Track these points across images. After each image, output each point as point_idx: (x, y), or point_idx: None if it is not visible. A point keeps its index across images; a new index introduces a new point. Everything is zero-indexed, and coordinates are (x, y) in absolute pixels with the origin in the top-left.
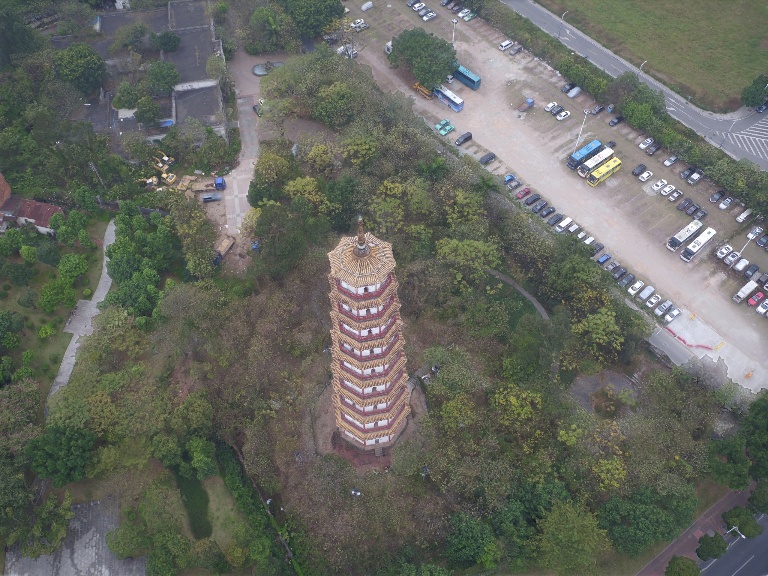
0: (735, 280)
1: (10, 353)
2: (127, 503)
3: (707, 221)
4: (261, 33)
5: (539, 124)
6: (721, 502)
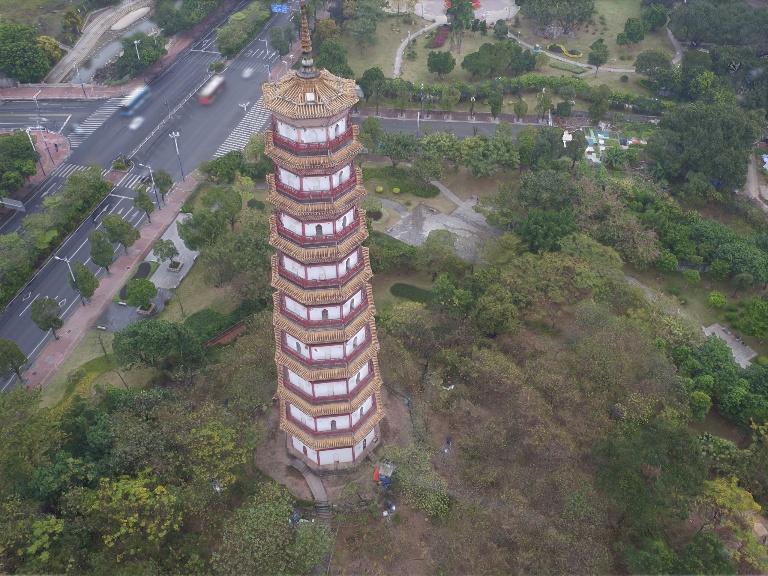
0: None
1: (716, 281)
2: None
3: None
4: None
5: None
6: None
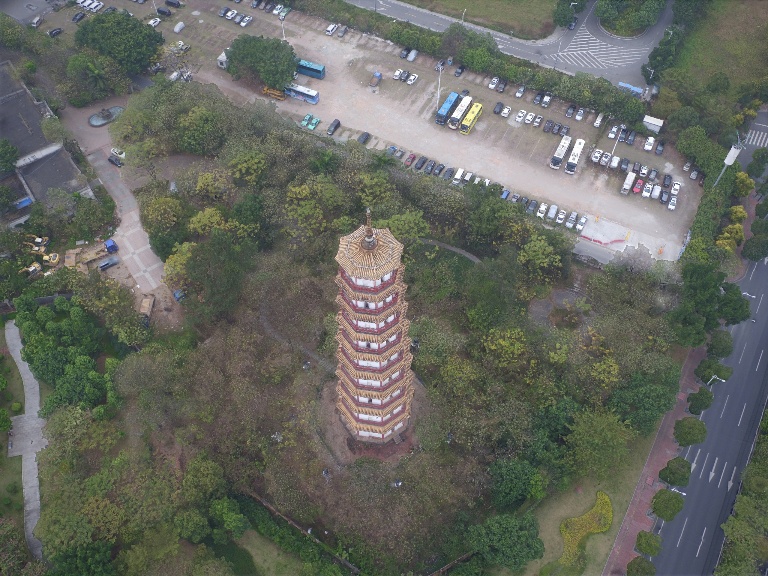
0: (615, 177)
1: None
2: None
3: (572, 134)
4: (85, 82)
5: (395, 93)
6: (686, 363)
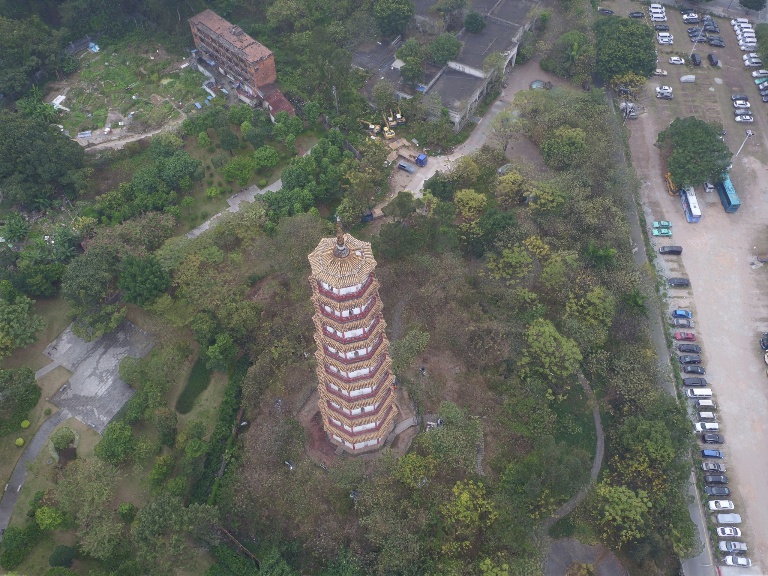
0: None
1: (184, 192)
2: (147, 344)
3: None
4: (560, 54)
5: (767, 283)
6: None
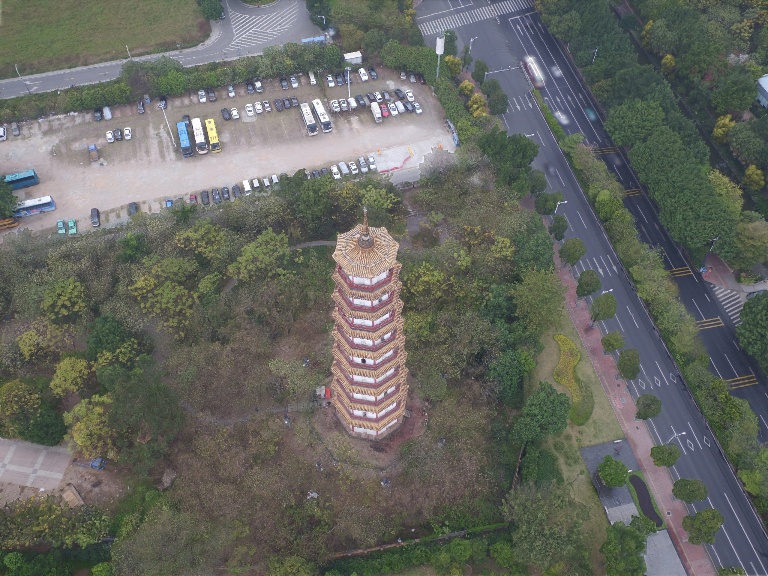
0: (362, 113)
1: None
2: None
3: (302, 101)
4: None
5: (123, 155)
6: None
